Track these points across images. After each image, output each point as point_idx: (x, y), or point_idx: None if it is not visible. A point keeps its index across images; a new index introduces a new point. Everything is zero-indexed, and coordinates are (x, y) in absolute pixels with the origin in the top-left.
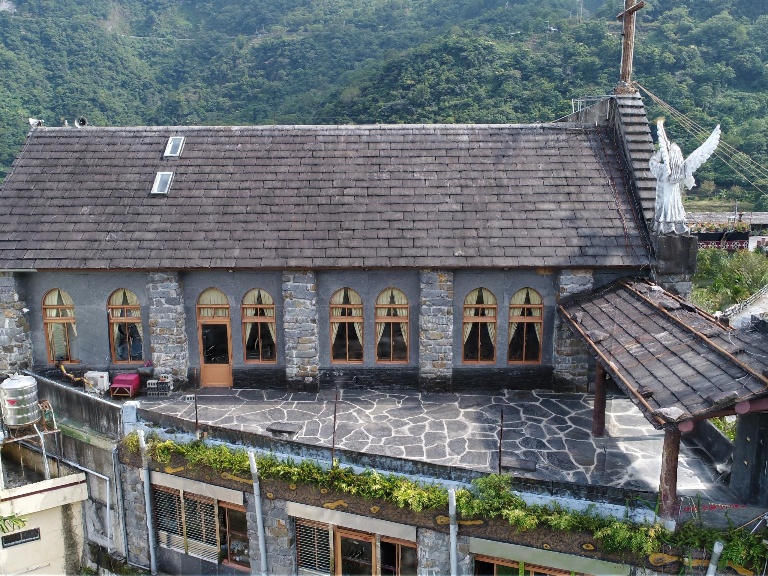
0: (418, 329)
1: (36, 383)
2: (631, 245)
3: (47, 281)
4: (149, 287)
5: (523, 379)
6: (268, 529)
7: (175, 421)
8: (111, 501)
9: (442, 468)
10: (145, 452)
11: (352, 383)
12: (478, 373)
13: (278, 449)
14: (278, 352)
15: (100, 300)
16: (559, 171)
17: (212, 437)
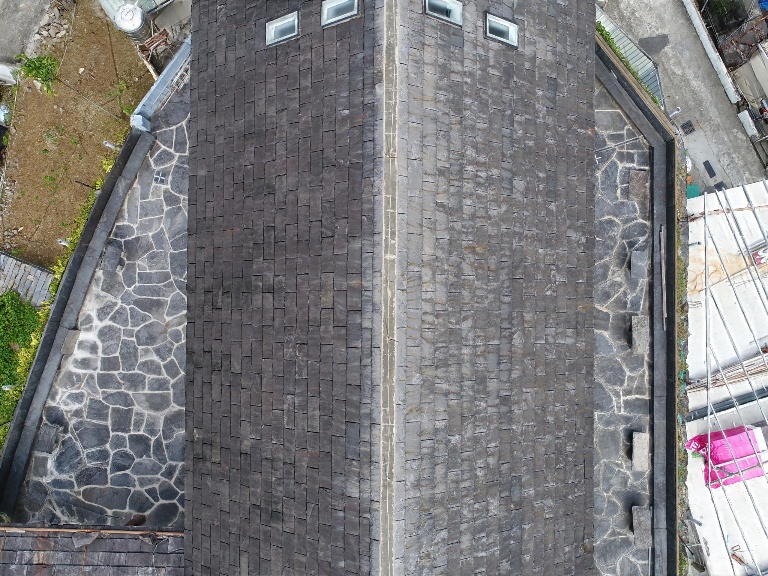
0: None
1: (134, 31)
2: None
3: None
4: None
5: None
6: None
7: None
8: None
9: None
10: None
11: None
12: None
13: None
14: None
15: None
16: None
17: None
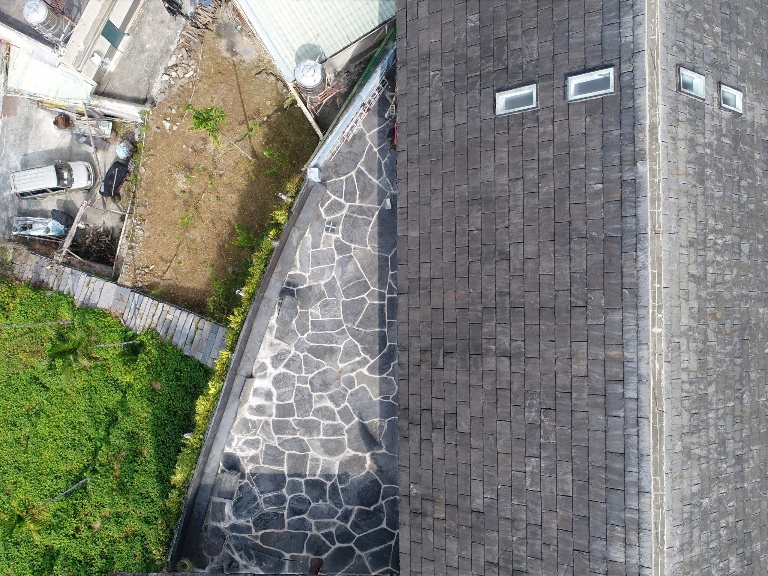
0: None
1: (314, 86)
2: None
3: None
4: None
5: None
6: None
7: None
8: None
9: None
10: (284, 200)
11: None
12: None
13: None
14: None
15: None
16: None
17: None
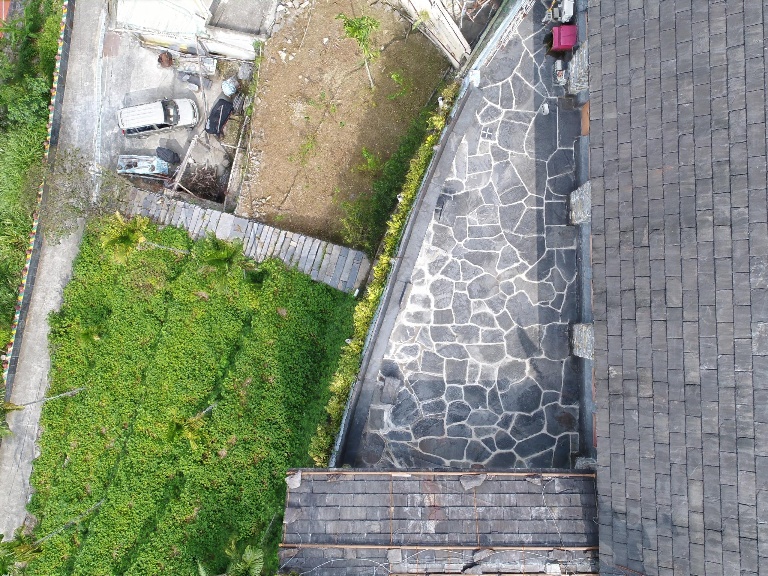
0: None
1: None
2: (628, 574)
3: None
4: None
5: None
6: None
7: None
8: None
9: None
10: (440, 106)
11: None
12: None
13: None
14: None
15: None
16: None
17: None
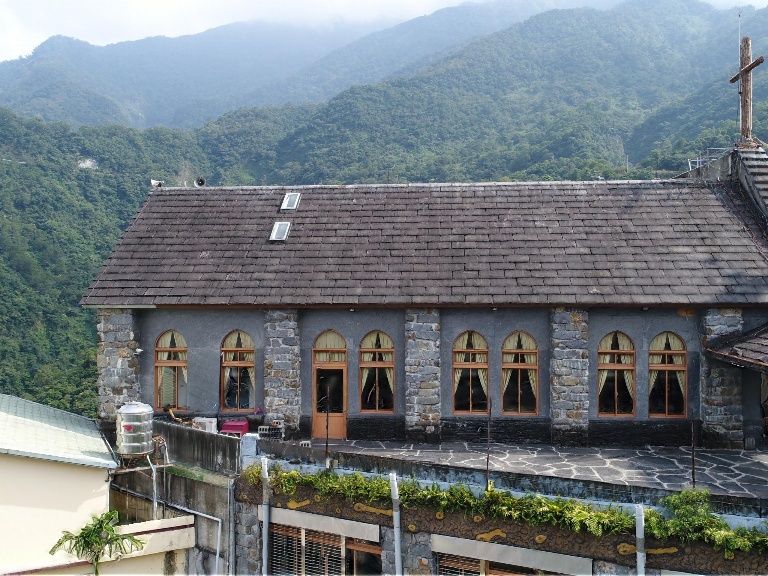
0: (548, 376)
1: None
2: None
3: (163, 322)
4: (267, 326)
5: (668, 434)
6: (407, 571)
7: (301, 450)
8: (221, 547)
9: (620, 488)
10: (267, 484)
11: (476, 435)
12: (617, 426)
13: (421, 475)
14: (396, 400)
15: (214, 342)
16: (688, 219)
17: (343, 466)
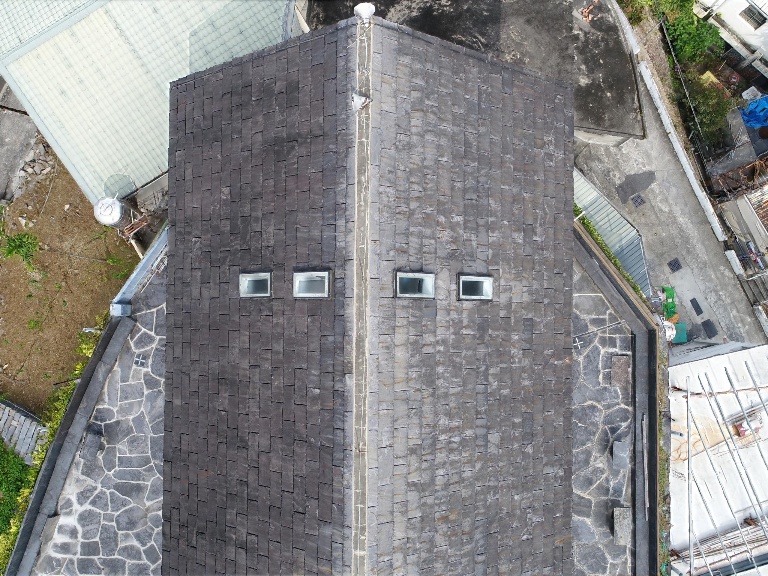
0: None
1: (113, 224)
2: None
3: None
4: None
5: None
6: None
7: None
8: None
9: None
10: None
11: None
12: None
13: None
14: None
15: None
16: None
17: None
